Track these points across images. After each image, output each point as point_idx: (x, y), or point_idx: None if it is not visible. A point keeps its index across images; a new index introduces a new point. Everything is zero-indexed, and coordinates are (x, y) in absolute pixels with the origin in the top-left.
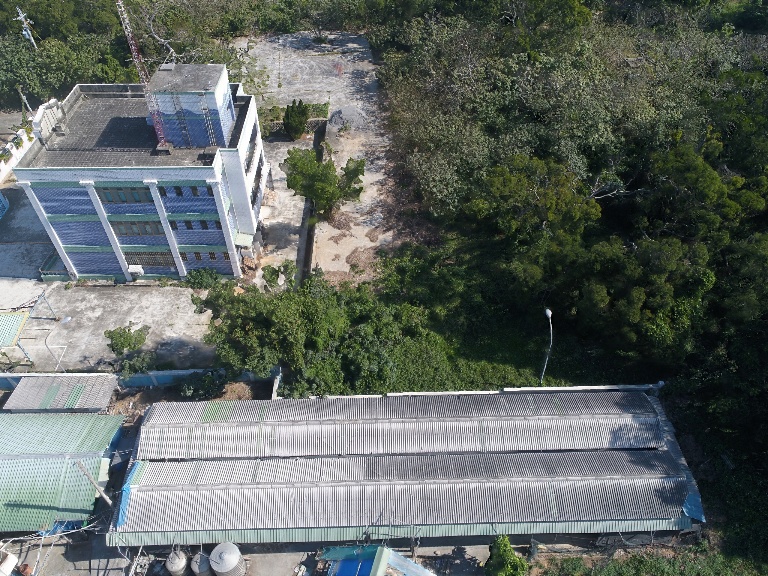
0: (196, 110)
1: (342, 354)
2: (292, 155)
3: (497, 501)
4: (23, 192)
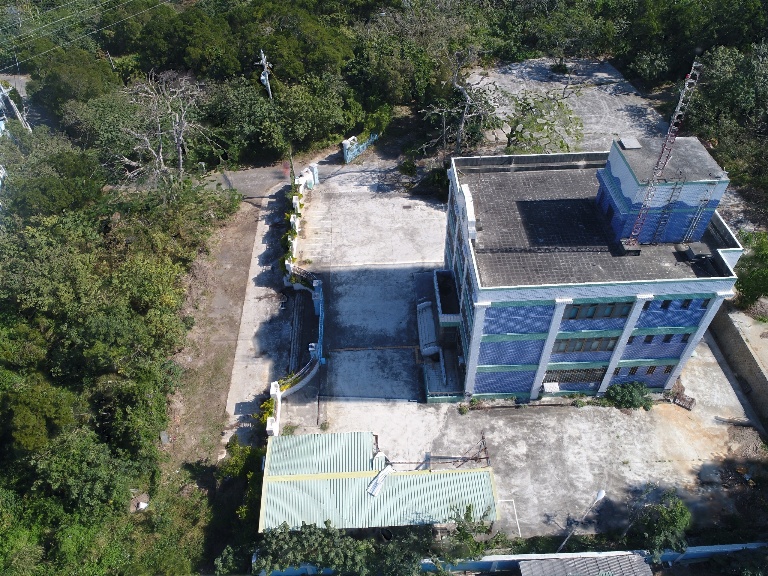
0: (692, 201)
1: None
2: (764, 245)
3: None
4: (329, 277)
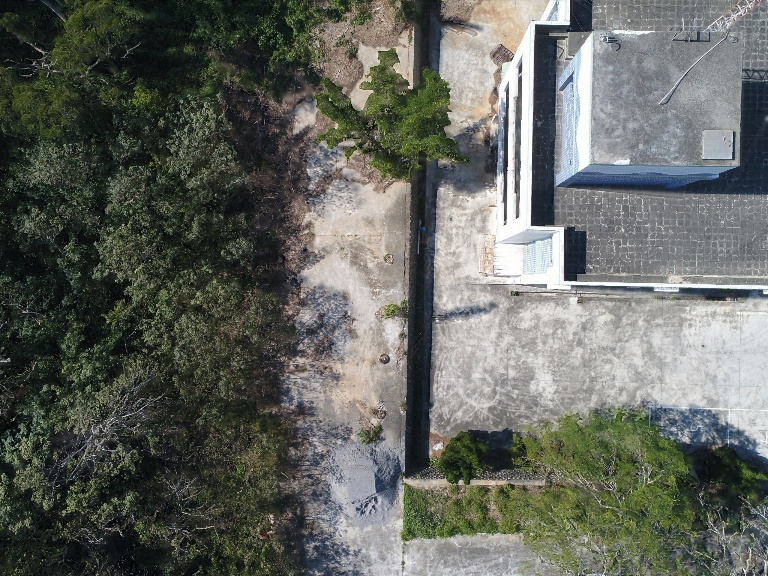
0: None
1: None
2: None
3: None
4: None
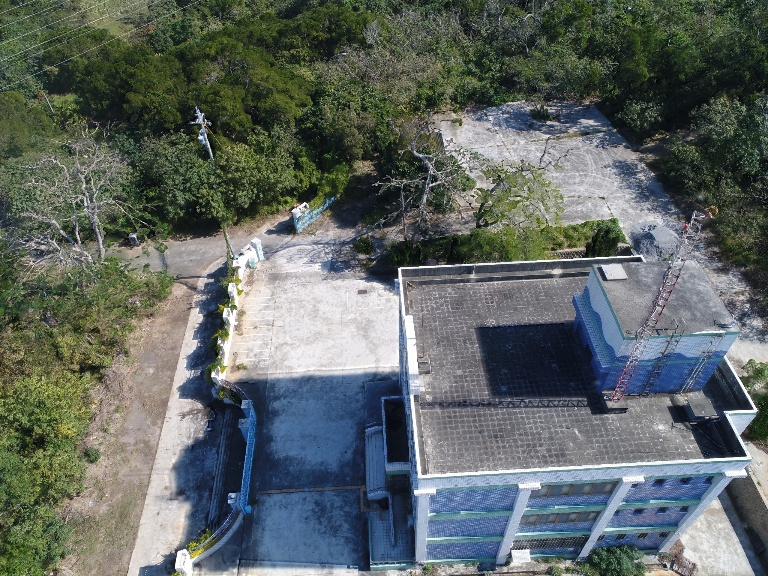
0: (692, 353)
1: None
2: None
3: None
4: (265, 388)
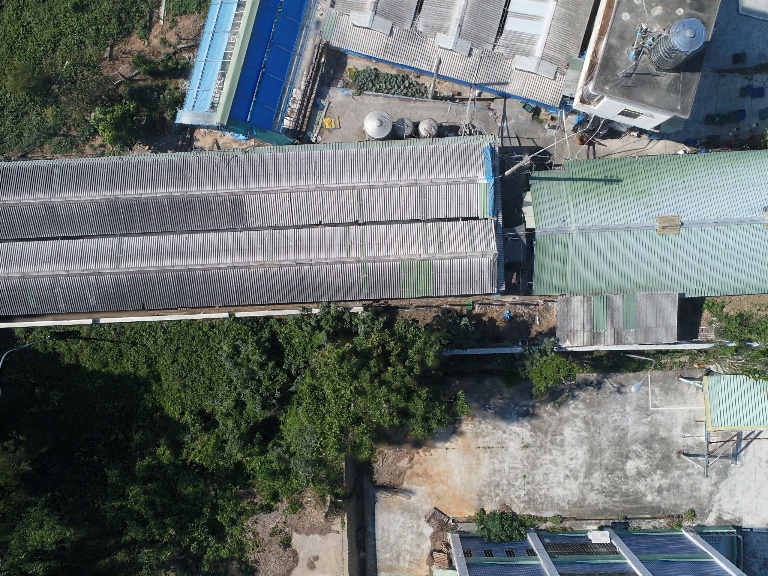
0: None
1: (283, 369)
2: None
3: (111, 179)
4: None
